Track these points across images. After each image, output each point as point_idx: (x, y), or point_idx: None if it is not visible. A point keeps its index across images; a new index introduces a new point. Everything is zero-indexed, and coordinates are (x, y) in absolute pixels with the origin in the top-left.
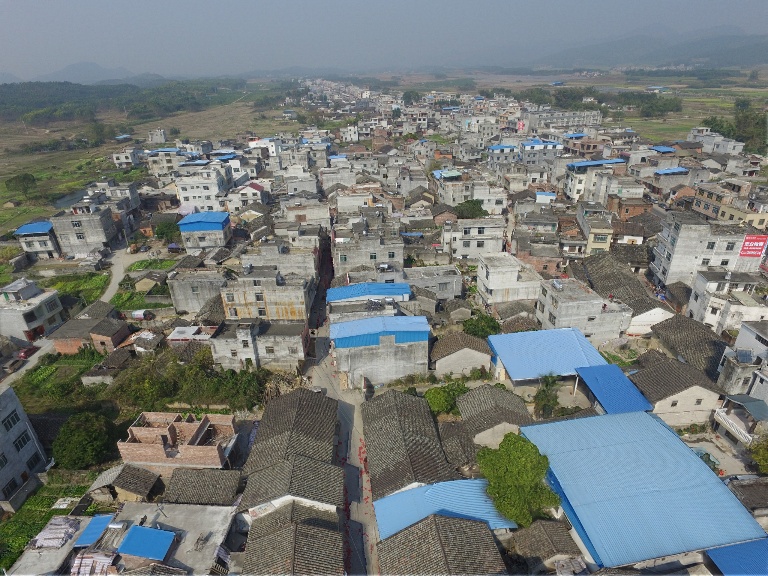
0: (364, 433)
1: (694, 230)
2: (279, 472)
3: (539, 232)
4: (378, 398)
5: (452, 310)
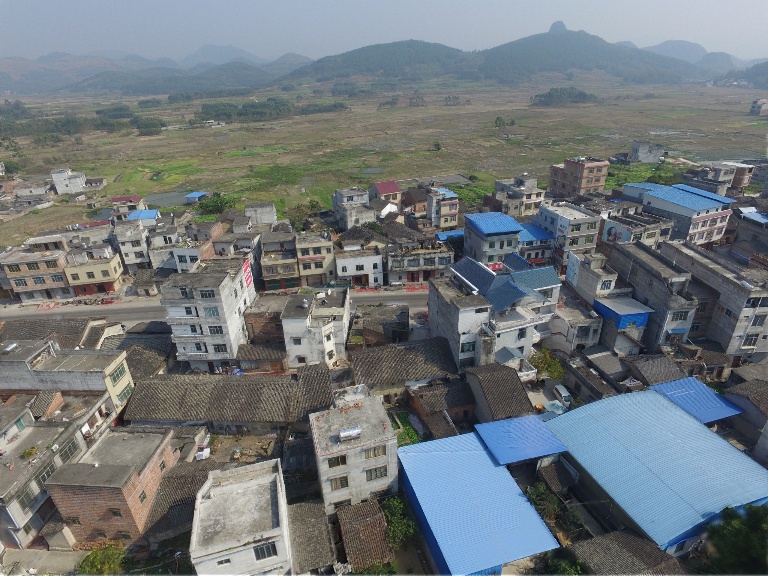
0: None
1: (225, 287)
2: None
3: (9, 451)
4: None
5: None
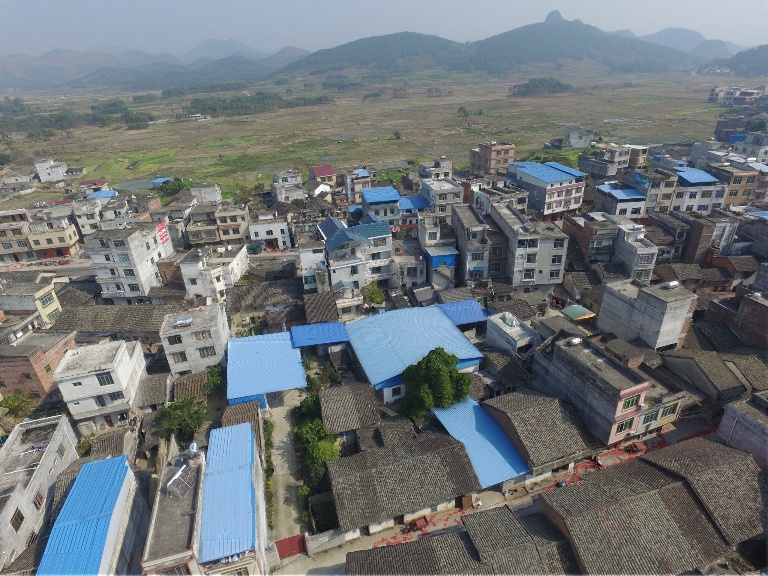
0: (393, 515)
1: (135, 239)
2: (507, 572)
3: None
4: (340, 500)
5: (121, 449)
